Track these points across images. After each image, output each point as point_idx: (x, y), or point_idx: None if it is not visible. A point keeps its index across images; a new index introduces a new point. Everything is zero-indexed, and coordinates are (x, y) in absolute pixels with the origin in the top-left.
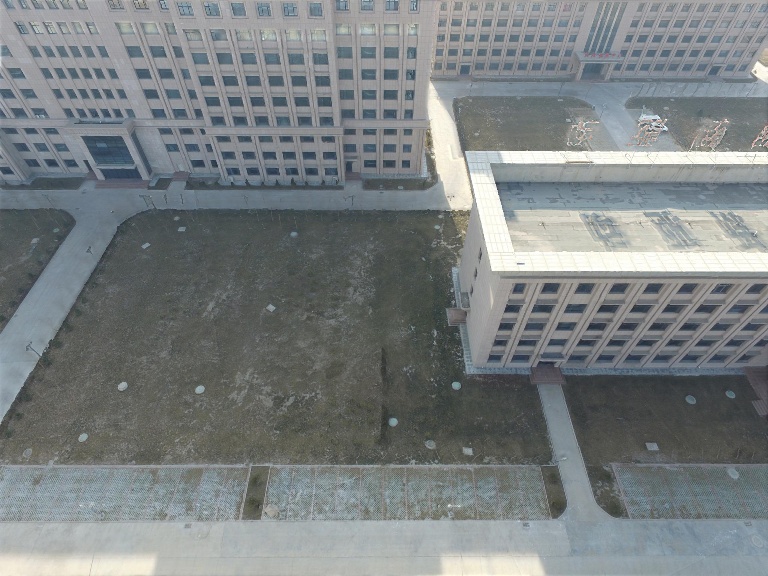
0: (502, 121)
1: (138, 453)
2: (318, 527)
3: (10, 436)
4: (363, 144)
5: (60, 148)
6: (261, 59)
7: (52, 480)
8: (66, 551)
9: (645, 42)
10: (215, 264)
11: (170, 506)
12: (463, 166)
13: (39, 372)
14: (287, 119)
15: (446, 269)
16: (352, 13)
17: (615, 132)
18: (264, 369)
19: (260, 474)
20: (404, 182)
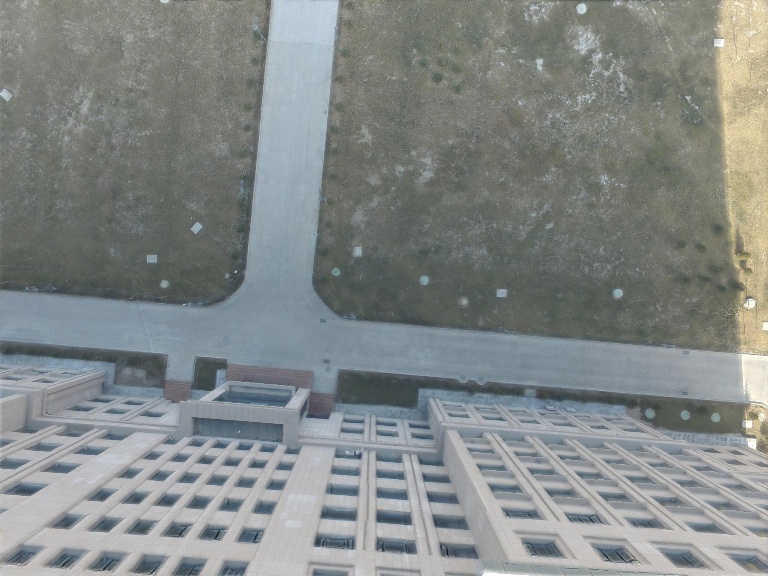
0: None
1: None
2: None
3: None
4: None
5: None
6: None
7: None
8: None
9: None
10: (91, 182)
11: None
12: None
13: (263, 25)
14: None
15: None
16: None
17: None
18: (8, 6)
19: None
20: None
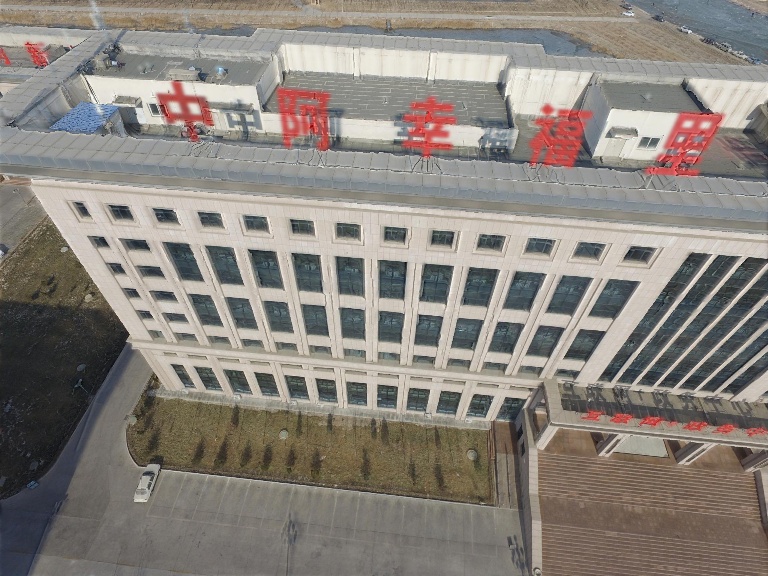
0: (6, 403)
1: None
2: None
3: None
4: None
5: None
6: None
7: None
8: None
9: None
10: None
11: None
12: None
13: None
14: None
15: None
16: None
17: None
18: None
19: None
20: None
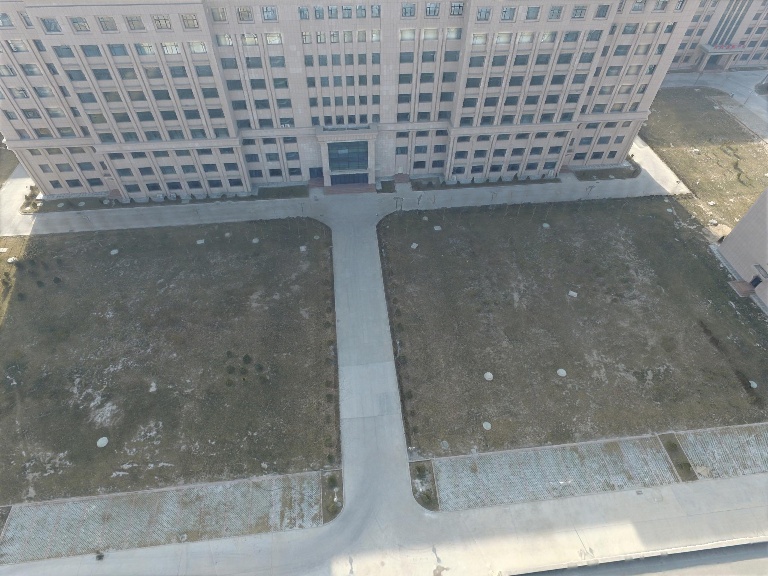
0: (658, 111)
1: (548, 434)
2: (752, 480)
3: (417, 431)
4: (581, 137)
5: (289, 157)
6: (533, 60)
7: (487, 466)
8: (547, 527)
9: (762, 33)
10: (492, 258)
11: (611, 477)
12: (653, 154)
13: (401, 371)
14: (530, 117)
15: (703, 247)
16: (623, 14)
17: (764, 116)
18: (606, 349)
19: (670, 441)
20: (611, 172)
